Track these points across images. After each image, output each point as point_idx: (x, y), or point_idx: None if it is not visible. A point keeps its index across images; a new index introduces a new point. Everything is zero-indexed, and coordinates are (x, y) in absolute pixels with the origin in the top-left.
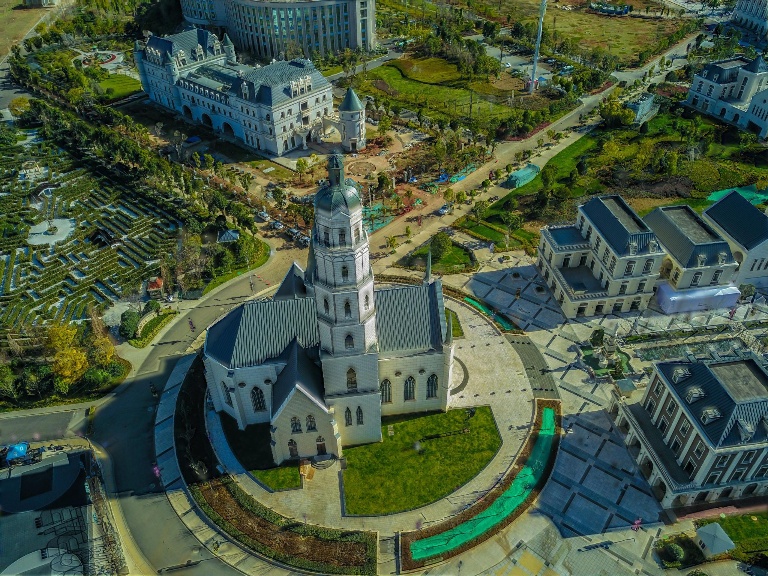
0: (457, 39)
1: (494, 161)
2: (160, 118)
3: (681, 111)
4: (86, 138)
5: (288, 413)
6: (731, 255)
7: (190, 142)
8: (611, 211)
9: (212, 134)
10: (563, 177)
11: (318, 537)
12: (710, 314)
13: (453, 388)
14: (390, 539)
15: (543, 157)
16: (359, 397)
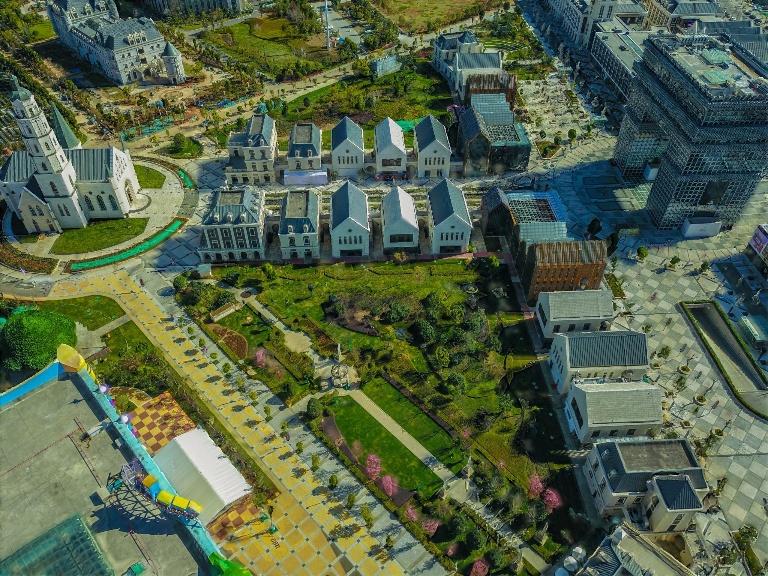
0: (300, 5)
1: (262, 95)
2: (62, 54)
3: (414, 68)
4: (4, 66)
5: (25, 203)
6: (315, 151)
7: (72, 72)
8: (252, 122)
9: (90, 67)
10: (297, 108)
11: (32, 259)
12: (309, 187)
13: (136, 209)
14: (65, 263)
15: (297, 95)
16: (61, 199)
